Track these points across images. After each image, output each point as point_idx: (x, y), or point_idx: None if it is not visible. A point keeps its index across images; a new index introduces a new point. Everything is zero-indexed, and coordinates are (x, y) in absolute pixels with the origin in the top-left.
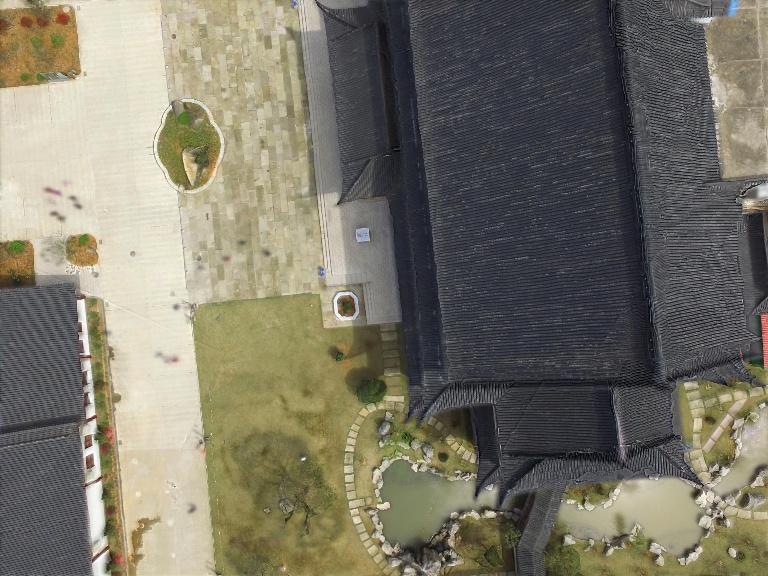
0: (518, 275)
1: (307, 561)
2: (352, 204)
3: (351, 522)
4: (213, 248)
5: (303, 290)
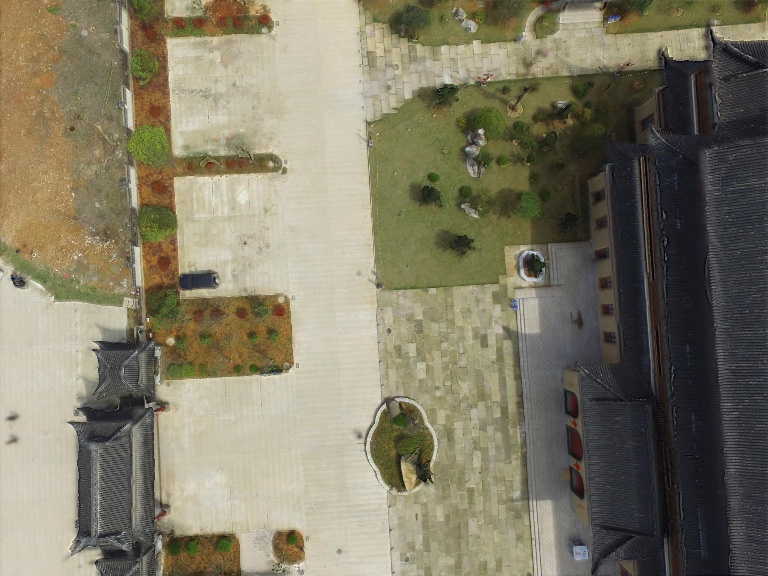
0: None
1: None
2: (565, 512)
3: None
4: (421, 549)
5: None
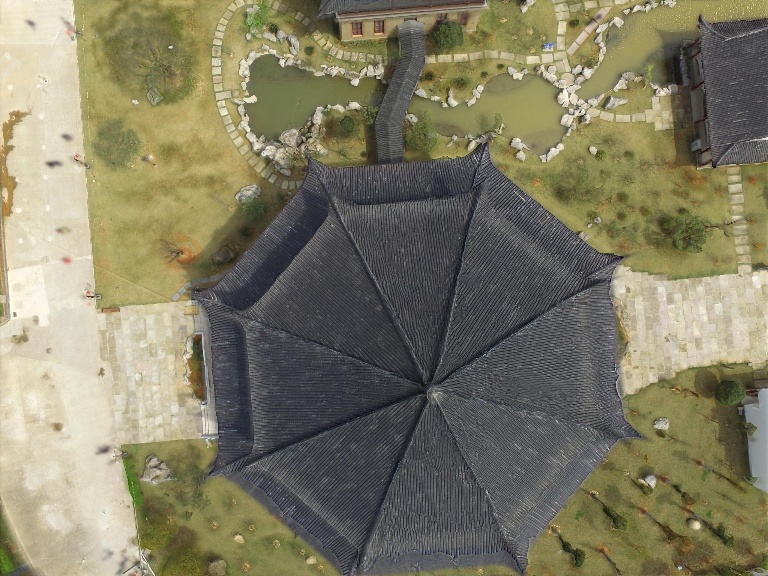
0: None
1: (174, 152)
2: None
3: (218, 113)
4: None
5: None
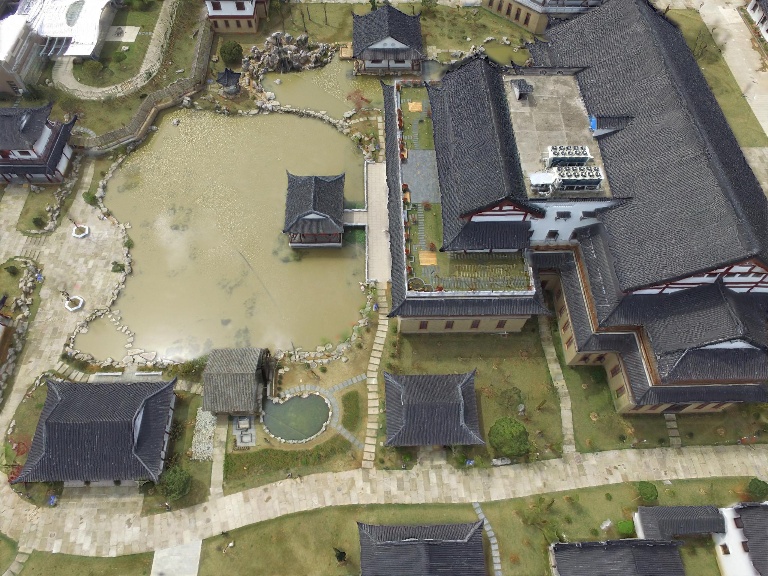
0: None
1: None
2: None
3: None
4: None
5: None
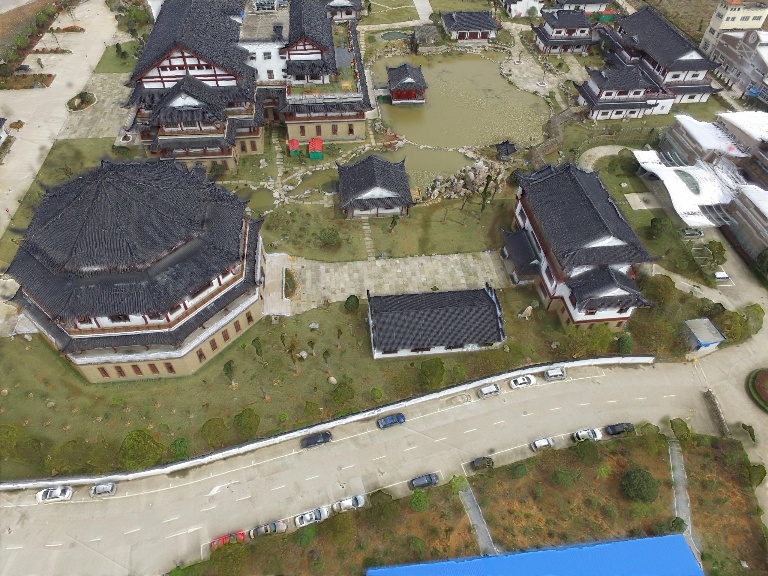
0: None
1: None
2: None
3: None
4: (76, 126)
5: (110, 136)
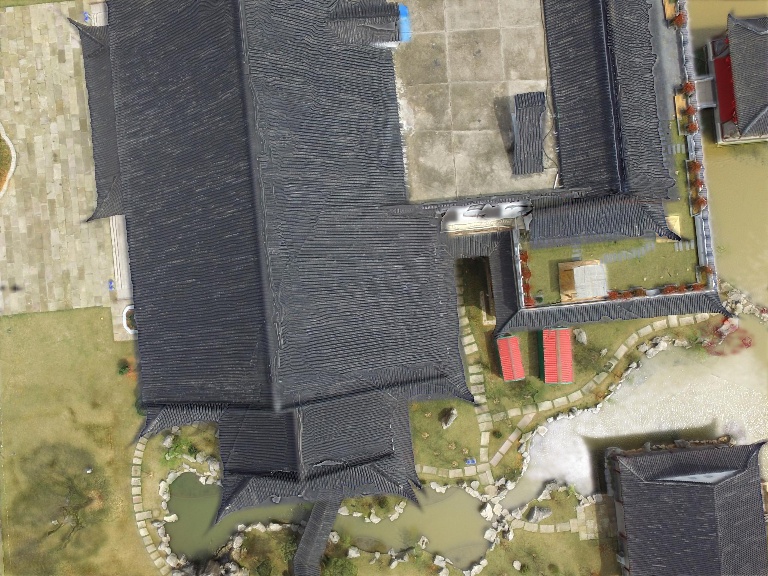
0: (190, 297)
1: (95, 573)
2: None
3: (138, 534)
4: (5, 261)
5: (94, 303)
